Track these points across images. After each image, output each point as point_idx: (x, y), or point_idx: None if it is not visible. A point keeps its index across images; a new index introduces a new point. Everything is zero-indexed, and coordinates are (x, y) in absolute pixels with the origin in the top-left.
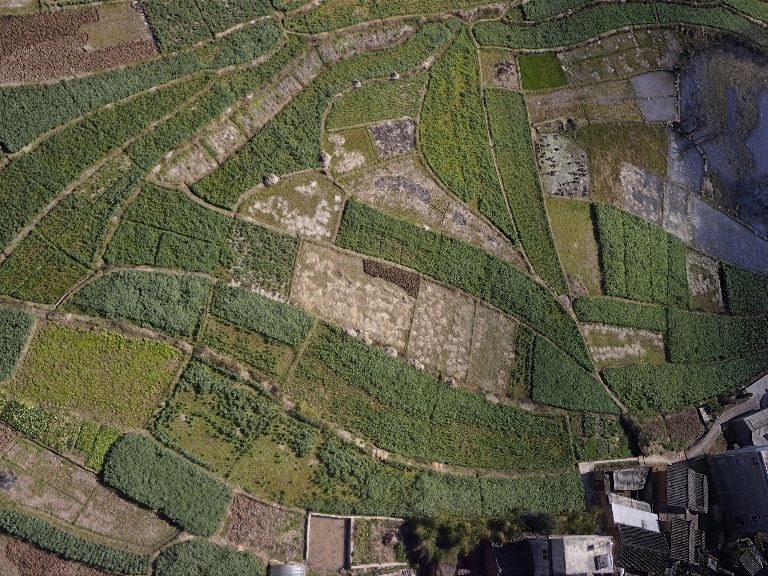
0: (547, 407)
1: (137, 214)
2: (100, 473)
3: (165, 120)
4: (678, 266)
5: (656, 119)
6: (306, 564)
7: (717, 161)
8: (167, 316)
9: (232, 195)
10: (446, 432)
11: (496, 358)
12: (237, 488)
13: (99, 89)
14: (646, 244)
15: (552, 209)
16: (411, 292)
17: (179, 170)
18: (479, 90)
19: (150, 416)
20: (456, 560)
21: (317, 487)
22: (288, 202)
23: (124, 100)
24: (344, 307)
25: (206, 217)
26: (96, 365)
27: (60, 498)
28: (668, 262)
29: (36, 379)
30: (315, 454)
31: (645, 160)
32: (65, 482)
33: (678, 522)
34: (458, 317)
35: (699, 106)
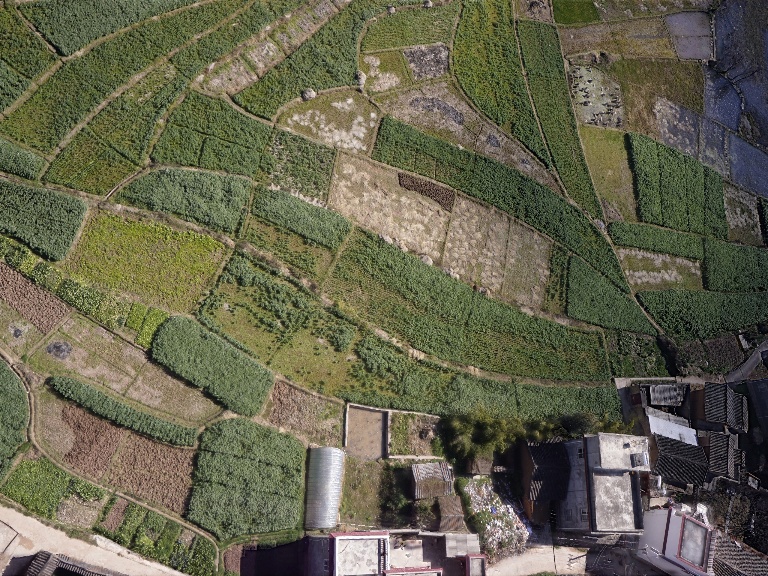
0: (582, 323)
1: (182, 119)
2: (149, 351)
3: (208, 34)
4: (715, 198)
5: (691, 57)
6: (345, 451)
7: (754, 100)
8: (211, 212)
9: (272, 106)
10: (481, 339)
11: (531, 274)
12: (278, 375)
13: (146, 2)
14: (682, 175)
15: (586, 137)
16: (446, 206)
17: (221, 81)
18: (511, 21)
19: (195, 303)
20: (492, 456)
21: (355, 380)
22: (325, 116)
23: (169, 14)
24: (380, 216)
25: (247, 125)
26: (144, 253)
27: (111, 371)
28: (705, 194)
29: (89, 262)
30: (353, 350)
31: (680, 96)
32: (116, 357)
33: (717, 436)
34: (492, 233)
35: (735, 45)
